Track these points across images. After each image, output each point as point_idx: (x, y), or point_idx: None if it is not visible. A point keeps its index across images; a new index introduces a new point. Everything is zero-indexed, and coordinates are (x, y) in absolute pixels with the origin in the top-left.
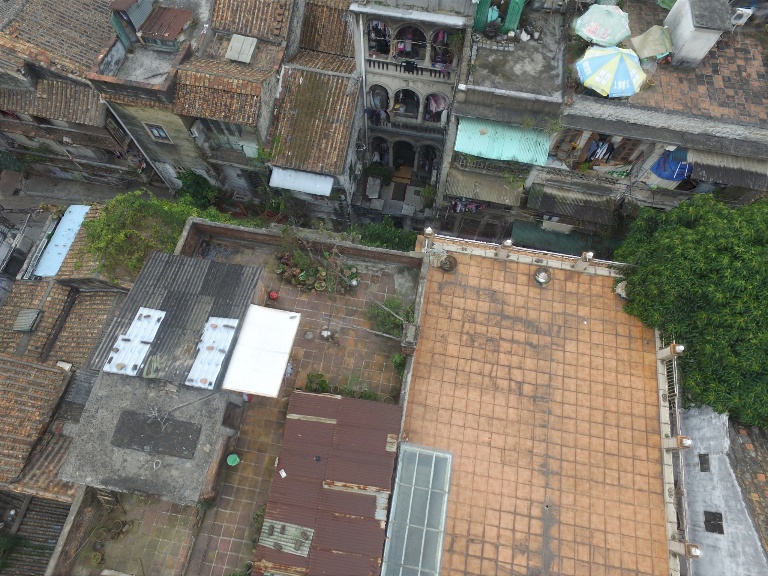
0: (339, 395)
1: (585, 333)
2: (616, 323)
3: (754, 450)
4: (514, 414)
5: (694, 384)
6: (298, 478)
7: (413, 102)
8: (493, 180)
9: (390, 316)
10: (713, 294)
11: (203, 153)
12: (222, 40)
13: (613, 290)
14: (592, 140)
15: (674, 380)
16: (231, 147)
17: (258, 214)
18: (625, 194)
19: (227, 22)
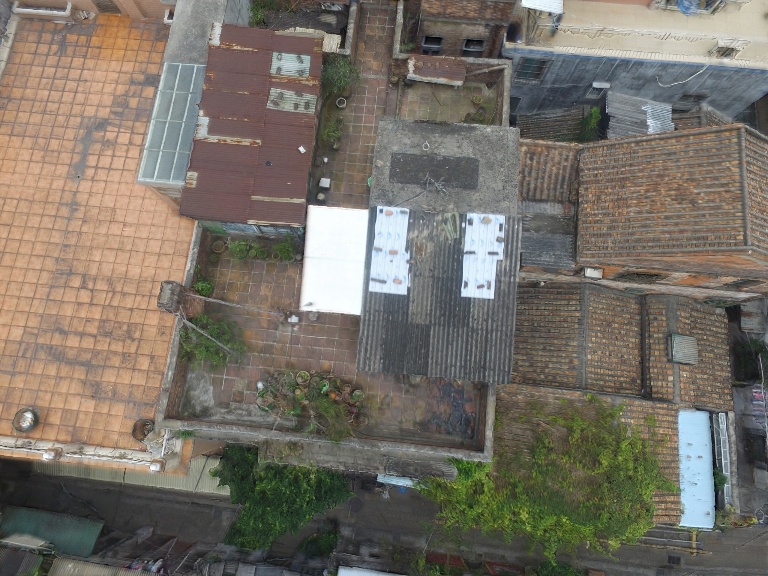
0: None
1: None
2: None
3: None
4: (95, 255)
5: None
6: (286, 147)
7: None
8: None
9: None
10: None
11: None
12: None
13: None
14: None
15: None
16: None
17: (471, 566)
18: None
19: None
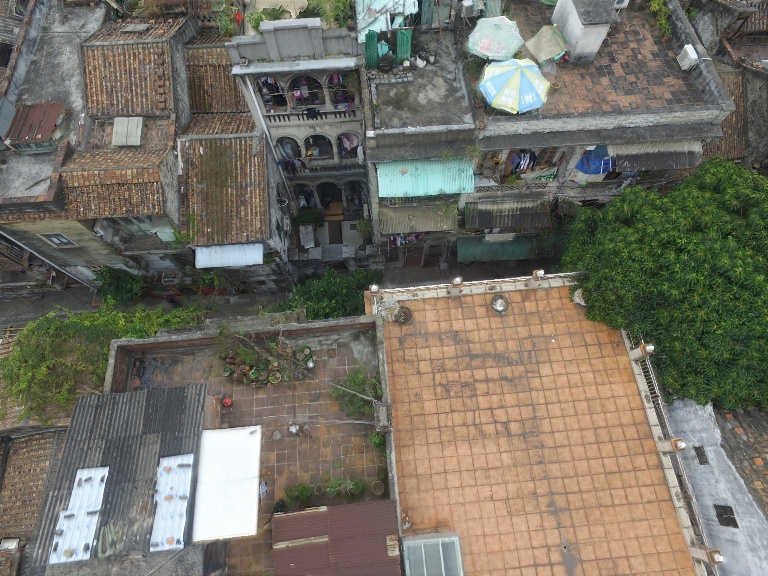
0: (324, 506)
1: (556, 352)
2: (583, 333)
3: (744, 433)
4: (508, 458)
5: (672, 381)
6: None
7: (325, 142)
8: (426, 209)
9: (357, 395)
10: (669, 292)
11: (115, 248)
12: (104, 126)
13: (571, 300)
14: (513, 153)
15: (653, 381)
16: (145, 233)
17: (194, 290)
18: (557, 194)
19: (104, 106)
